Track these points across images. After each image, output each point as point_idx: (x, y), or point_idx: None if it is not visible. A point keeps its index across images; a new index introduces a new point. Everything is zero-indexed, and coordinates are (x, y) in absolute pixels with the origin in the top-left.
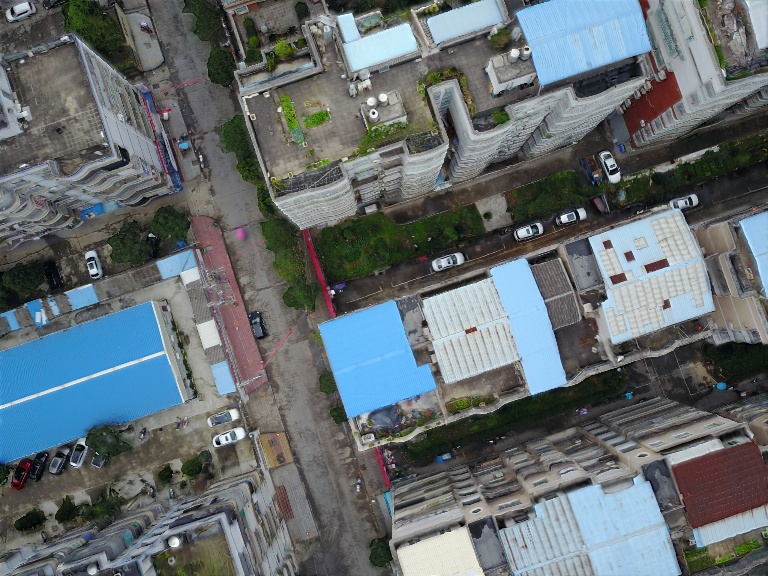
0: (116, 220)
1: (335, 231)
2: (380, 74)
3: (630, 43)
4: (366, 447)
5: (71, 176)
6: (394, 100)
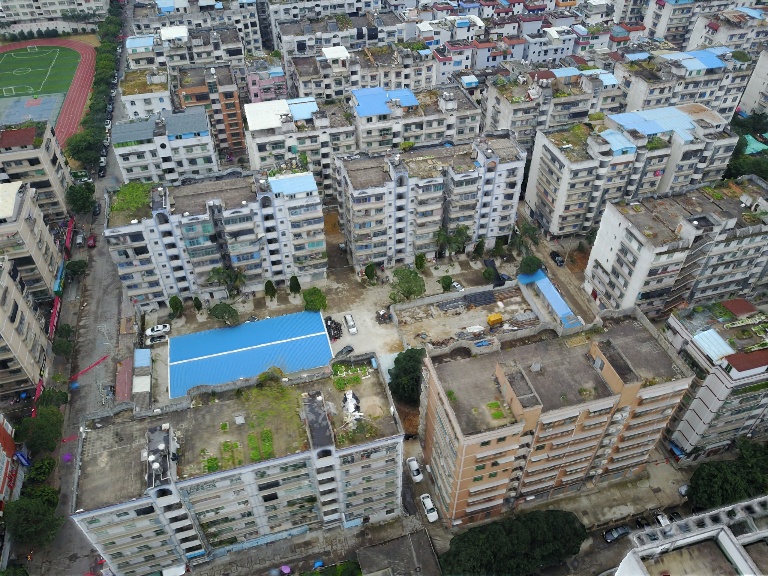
0: None
1: None
2: None
3: None
4: (2, 256)
5: (122, 404)
6: None
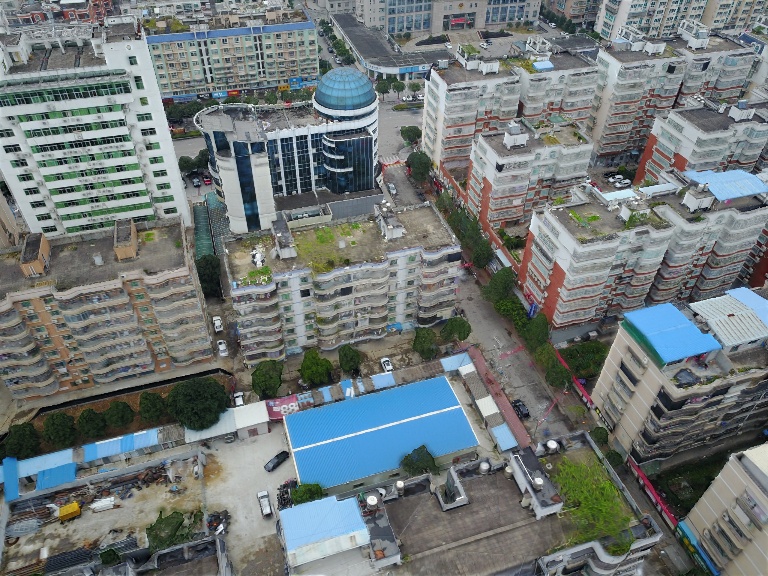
0: (402, 342)
1: (567, 351)
2: None
3: (759, 188)
4: (683, 390)
5: (435, 253)
6: (641, 203)
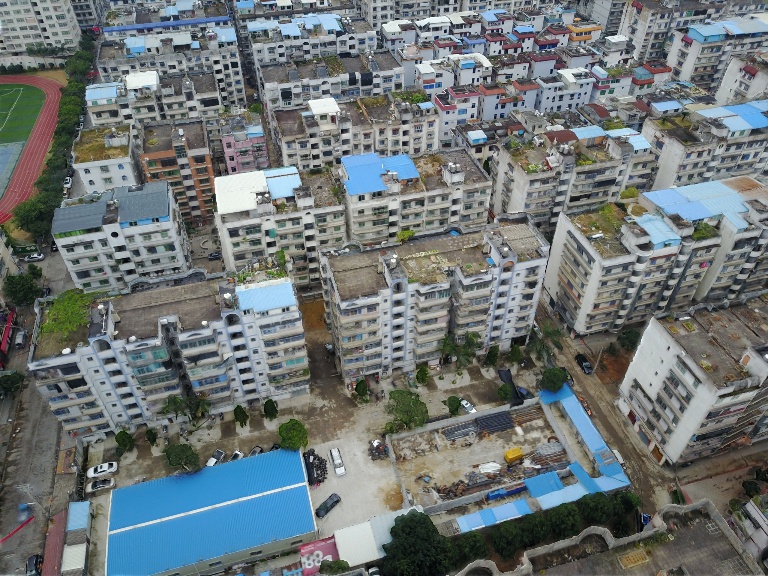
0: None
1: None
2: None
3: None
4: None
5: None
6: None
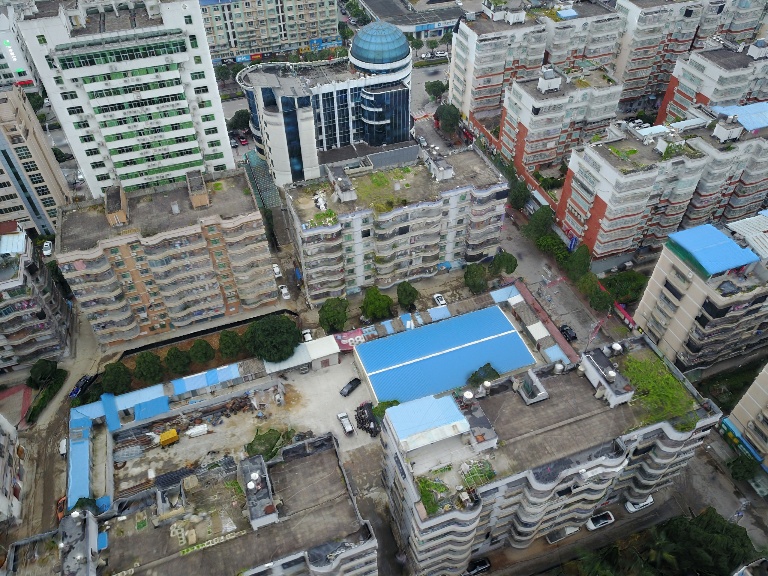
0: (451, 280)
1: (606, 280)
2: (657, 139)
3: None
4: (727, 298)
5: (485, 191)
6: (676, 135)
